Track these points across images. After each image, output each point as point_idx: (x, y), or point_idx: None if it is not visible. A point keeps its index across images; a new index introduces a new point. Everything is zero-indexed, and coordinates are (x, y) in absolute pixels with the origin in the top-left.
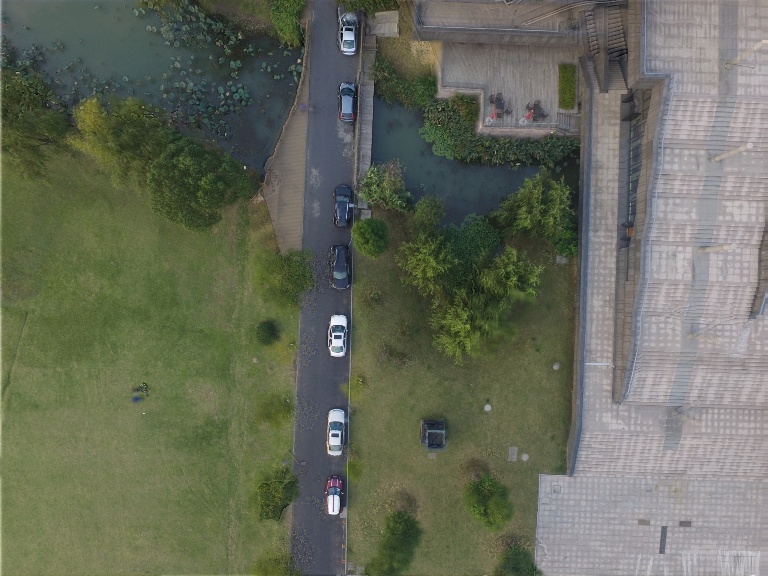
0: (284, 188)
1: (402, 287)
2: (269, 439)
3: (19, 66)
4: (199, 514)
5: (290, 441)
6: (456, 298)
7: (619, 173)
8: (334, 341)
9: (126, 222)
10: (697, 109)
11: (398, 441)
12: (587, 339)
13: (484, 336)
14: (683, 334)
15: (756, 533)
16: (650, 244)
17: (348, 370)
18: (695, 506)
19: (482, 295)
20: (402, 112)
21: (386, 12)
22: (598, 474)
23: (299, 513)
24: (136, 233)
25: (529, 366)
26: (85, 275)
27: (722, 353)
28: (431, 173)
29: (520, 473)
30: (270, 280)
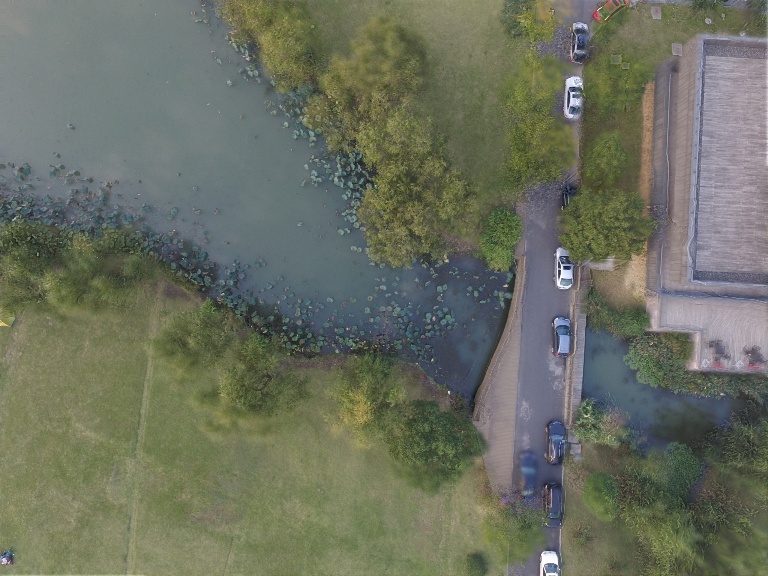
0: (495, 421)
1: (610, 521)
2: None
3: (223, 285)
4: None
5: None
6: (661, 531)
7: None
8: None
9: (332, 448)
10: None
11: None
12: None
13: (690, 571)
14: None
15: None
16: None
17: None
18: None
19: (688, 529)
20: (608, 340)
21: (613, 259)
22: None
23: None
24: (342, 460)
25: None
26: (291, 501)
27: None
28: (635, 400)
29: None
30: (478, 511)
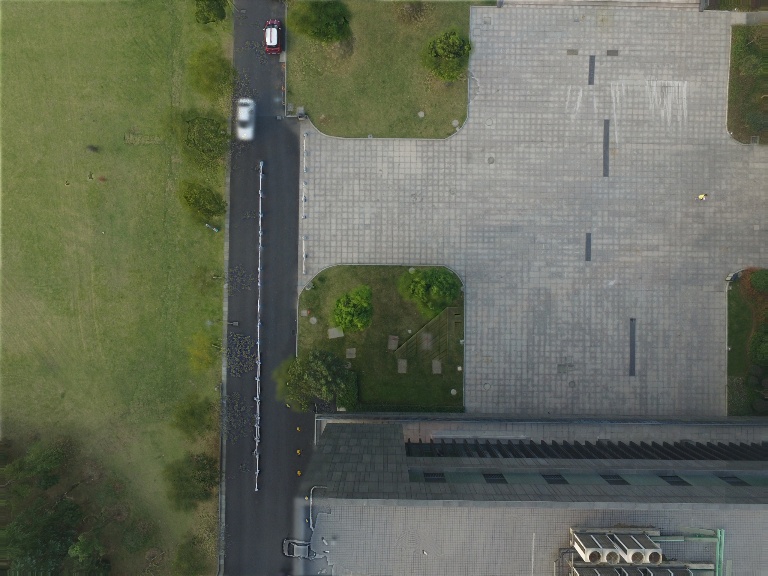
0: None
1: None
2: None
3: None
4: (143, 65)
5: None
6: None
7: None
8: None
9: None
10: None
11: None
12: None
13: None
14: None
15: (682, 62)
16: None
17: None
18: (621, 35)
19: None
20: None
21: None
22: (527, 4)
23: (240, 59)
24: None
25: None
26: None
27: None
28: None
29: (451, 5)
30: None
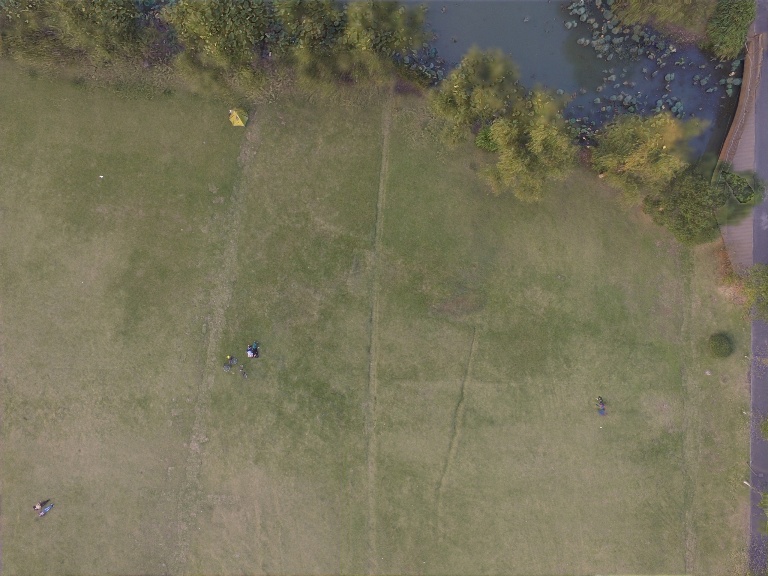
0: (734, 201)
1: None
2: (725, 451)
3: (454, 79)
4: (656, 527)
5: (747, 453)
6: None
7: None
8: None
9: (569, 236)
10: None
11: None
12: None
13: None
14: None
15: None
16: None
17: None
18: None
19: None
20: None
21: None
22: None
23: (757, 524)
24: (580, 247)
25: None
26: (531, 289)
27: None
28: None
29: None
30: (719, 293)
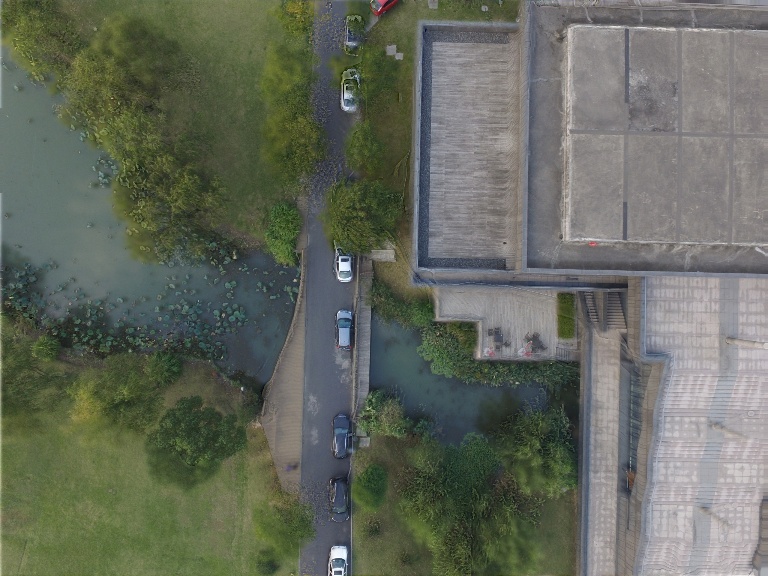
0: (282, 417)
1: (402, 514)
2: None
3: (12, 289)
4: None
5: None
6: (456, 523)
7: (619, 416)
8: None
9: (123, 448)
10: (698, 383)
11: None
12: None
13: (485, 563)
14: None
15: None
16: (651, 505)
17: None
18: None
19: (482, 520)
20: (400, 331)
21: (382, 250)
22: None
23: None
24: (134, 459)
25: None
26: (83, 503)
27: None
28: (430, 392)
29: None
30: (269, 508)
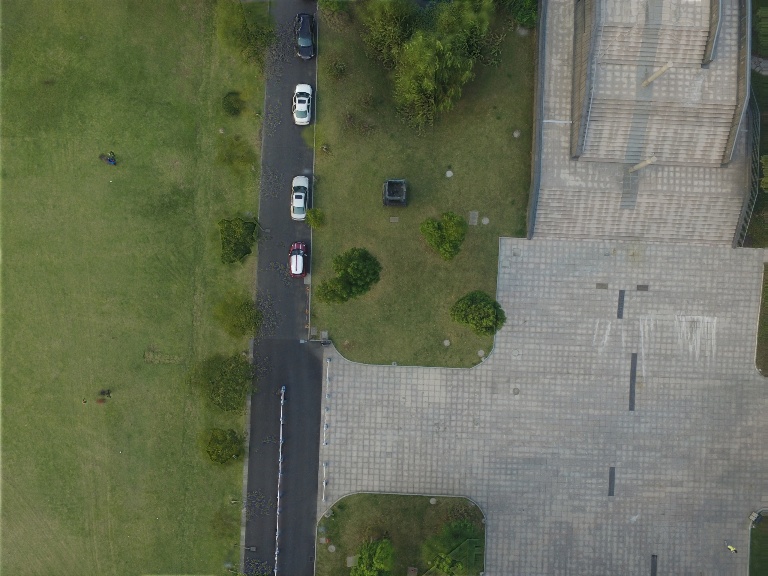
0: None
1: (367, 60)
2: (234, 208)
3: None
4: (165, 281)
5: (255, 209)
6: (420, 73)
7: None
8: (298, 105)
9: None
10: None
11: (361, 206)
12: (546, 96)
13: (447, 109)
14: (638, 81)
15: (712, 298)
16: None
17: (313, 140)
18: (652, 270)
19: (446, 70)
20: None
21: None
22: (557, 237)
23: (263, 279)
24: (105, 9)
25: (490, 133)
26: (54, 49)
27: (676, 102)
28: None
29: (480, 236)
30: (237, 54)
